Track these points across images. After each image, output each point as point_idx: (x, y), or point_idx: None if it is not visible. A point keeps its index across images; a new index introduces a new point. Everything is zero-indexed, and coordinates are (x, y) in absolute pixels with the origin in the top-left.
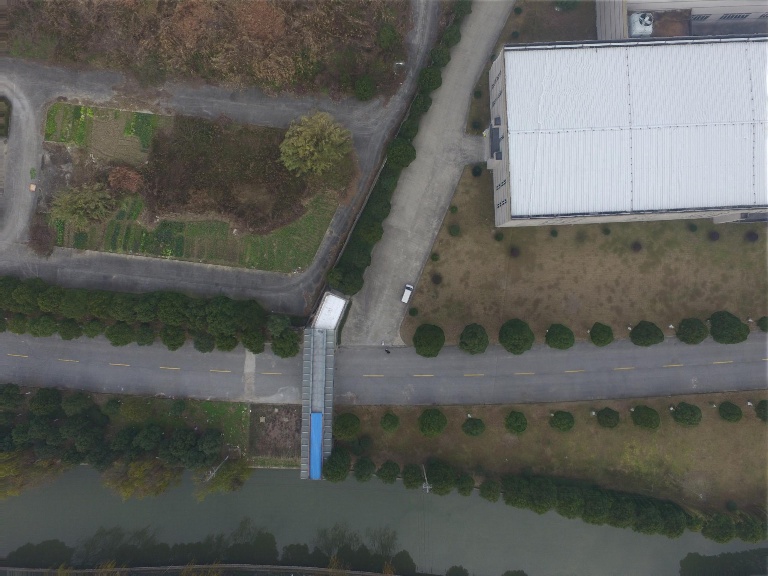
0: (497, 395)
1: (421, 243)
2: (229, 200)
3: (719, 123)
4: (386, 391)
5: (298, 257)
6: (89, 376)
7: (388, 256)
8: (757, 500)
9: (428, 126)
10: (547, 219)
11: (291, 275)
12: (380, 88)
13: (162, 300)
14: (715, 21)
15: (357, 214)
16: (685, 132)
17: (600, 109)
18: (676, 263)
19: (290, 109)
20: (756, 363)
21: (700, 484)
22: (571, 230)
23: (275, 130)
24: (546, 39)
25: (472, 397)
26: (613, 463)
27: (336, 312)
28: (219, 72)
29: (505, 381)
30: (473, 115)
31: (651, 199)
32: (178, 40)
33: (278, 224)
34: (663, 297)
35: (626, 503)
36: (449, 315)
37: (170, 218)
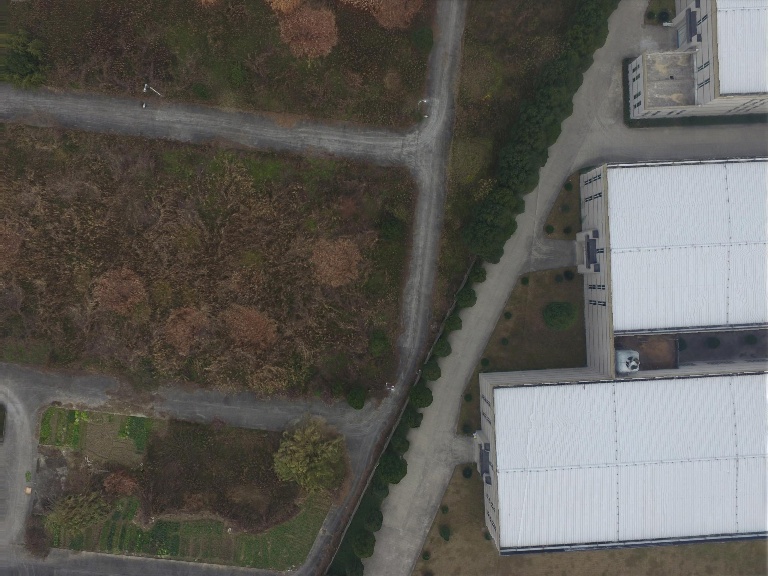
0: None
1: (413, 541)
2: (223, 506)
3: (703, 459)
4: None
5: (292, 555)
6: None
7: (380, 553)
8: None
9: (419, 427)
10: (535, 551)
11: (285, 573)
12: (372, 392)
13: None
14: None
15: (350, 517)
16: (670, 468)
17: (587, 446)
18: (662, 556)
19: (283, 412)
20: None
21: None
22: None
23: (268, 436)
24: (535, 343)
25: None
26: None
27: None
28: (212, 384)
29: None
30: (464, 417)
31: (637, 530)
32: (171, 349)
33: (272, 525)
34: None
35: None
36: None
37: (165, 518)
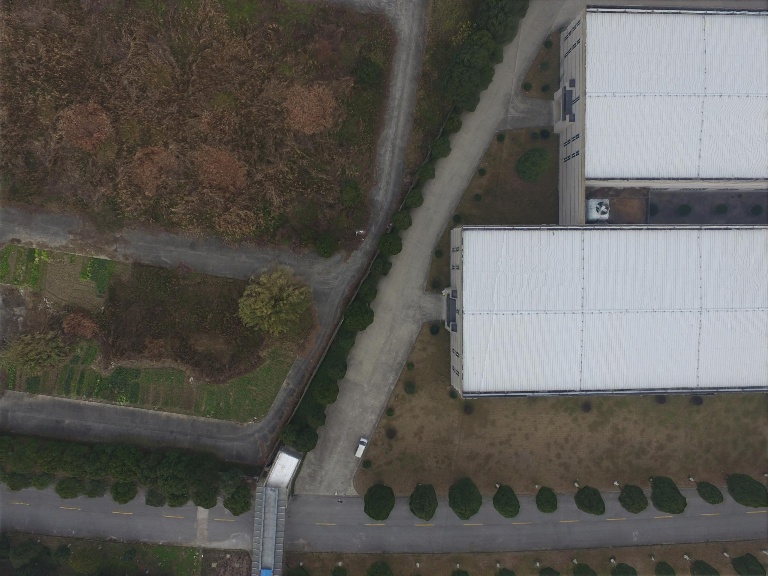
0: (446, 544)
1: (377, 397)
2: (185, 352)
3: (668, 310)
4: (337, 539)
5: (254, 407)
6: (39, 519)
7: (344, 409)
8: None
9: (388, 282)
10: (498, 396)
11: (247, 425)
12: (342, 244)
13: (113, 458)
14: (674, 190)
15: (314, 369)
16: (635, 317)
17: (554, 292)
18: (624, 423)
19: (250, 260)
20: (694, 518)
21: None
22: None
23: (234, 283)
24: (508, 201)
25: (421, 546)
26: None
27: (289, 469)
28: (178, 225)
29: (454, 531)
30: (433, 273)
31: (599, 379)
32: (137, 188)
33: (235, 375)
34: (610, 455)
35: None
36: (402, 467)
37: (125, 364)
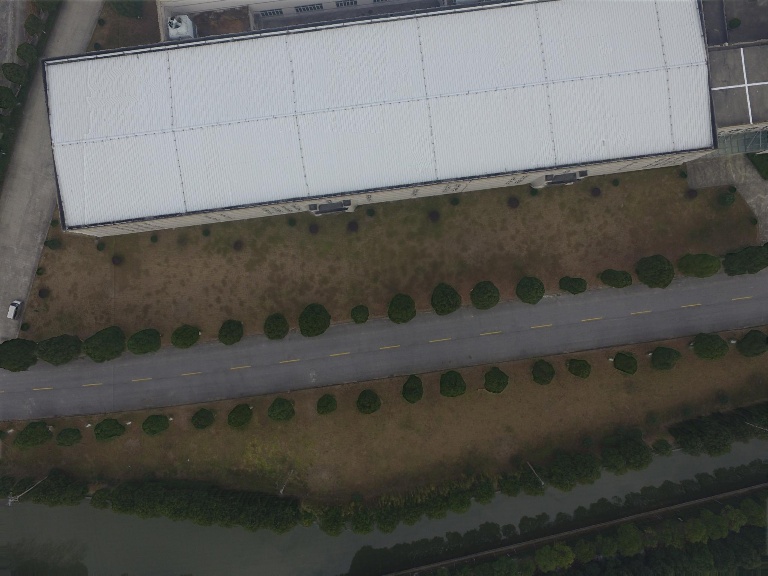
0: (117, 403)
1: (28, 258)
2: None
3: (261, 118)
4: (8, 407)
5: None
6: None
7: None
8: (382, 490)
9: (25, 143)
10: (102, 227)
11: None
12: None
13: None
14: (297, 14)
15: None
16: (228, 130)
17: (143, 114)
18: (281, 259)
19: None
20: (373, 352)
21: (325, 478)
22: (173, 234)
23: None
24: None
25: (92, 407)
26: (236, 463)
27: None
28: None
29: (123, 388)
30: None
31: (204, 199)
32: None
33: None
34: (272, 293)
35: (229, 503)
36: (62, 327)
37: None
